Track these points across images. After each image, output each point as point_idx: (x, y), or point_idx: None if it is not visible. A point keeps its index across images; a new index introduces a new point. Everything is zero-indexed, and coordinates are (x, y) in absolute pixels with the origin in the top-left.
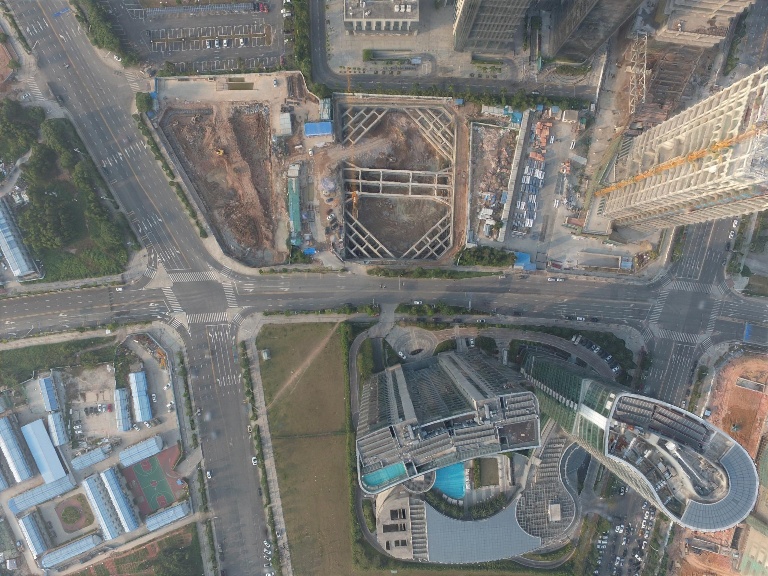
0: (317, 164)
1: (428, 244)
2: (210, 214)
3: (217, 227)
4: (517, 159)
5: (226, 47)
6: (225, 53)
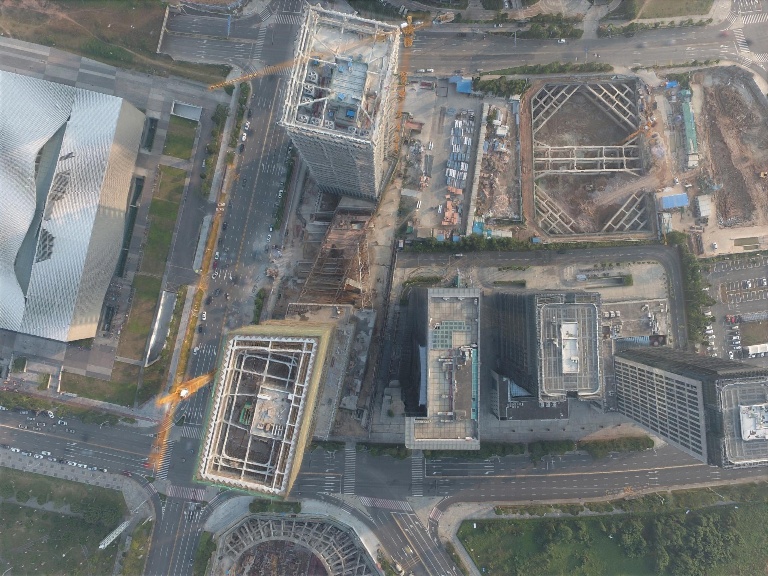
0: (669, 170)
1: (554, 100)
2: (766, 117)
3: (759, 105)
4: (476, 185)
5: (763, 279)
6: (764, 273)
